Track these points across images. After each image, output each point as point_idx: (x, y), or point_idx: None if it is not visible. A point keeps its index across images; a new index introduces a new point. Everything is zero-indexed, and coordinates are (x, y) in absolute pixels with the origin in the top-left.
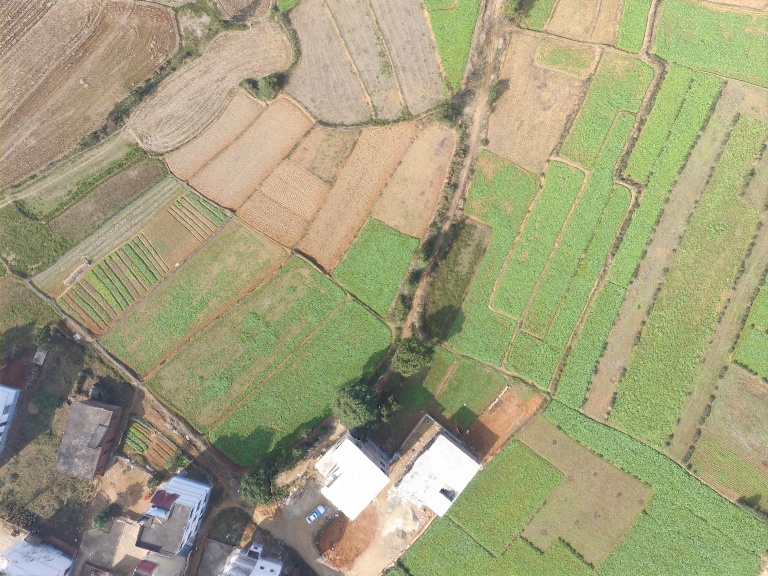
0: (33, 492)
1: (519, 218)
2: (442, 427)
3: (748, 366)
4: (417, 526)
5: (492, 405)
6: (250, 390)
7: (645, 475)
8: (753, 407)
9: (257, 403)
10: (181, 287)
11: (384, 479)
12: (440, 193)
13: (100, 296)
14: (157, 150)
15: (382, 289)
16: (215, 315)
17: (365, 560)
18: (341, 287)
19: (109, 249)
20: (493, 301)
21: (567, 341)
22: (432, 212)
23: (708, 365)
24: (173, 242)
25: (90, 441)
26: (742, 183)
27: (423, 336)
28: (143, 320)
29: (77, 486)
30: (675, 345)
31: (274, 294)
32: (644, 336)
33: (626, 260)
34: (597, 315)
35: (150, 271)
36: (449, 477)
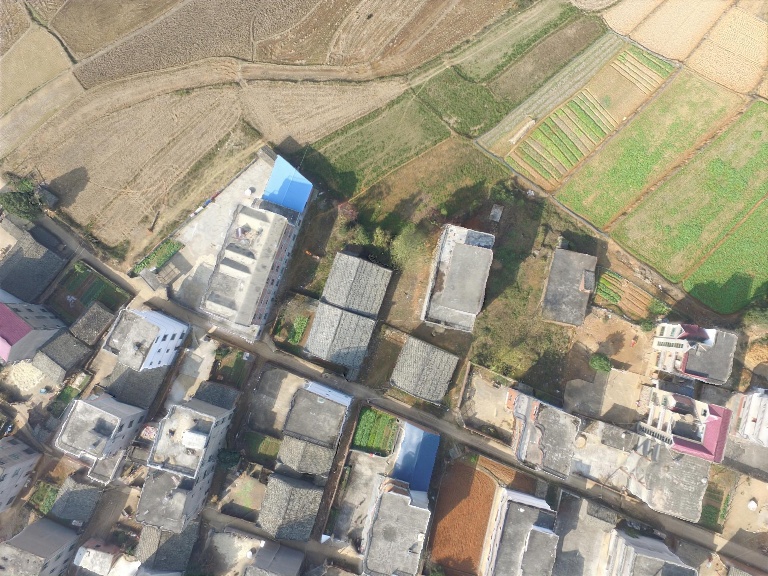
0: (507, 345)
1: None
2: None
3: None
4: None
5: None
6: (722, 237)
7: None
8: None
9: (732, 249)
10: (634, 139)
11: None
12: None
13: (548, 153)
14: (591, 8)
15: None
16: (672, 165)
17: None
18: None
19: (553, 107)
20: None
21: None
22: None
23: None
24: (619, 96)
25: (585, 284)
26: None
27: None
28: (597, 174)
29: (552, 338)
30: None
31: (738, 139)
32: None
33: None
34: None
35: (598, 126)
36: None
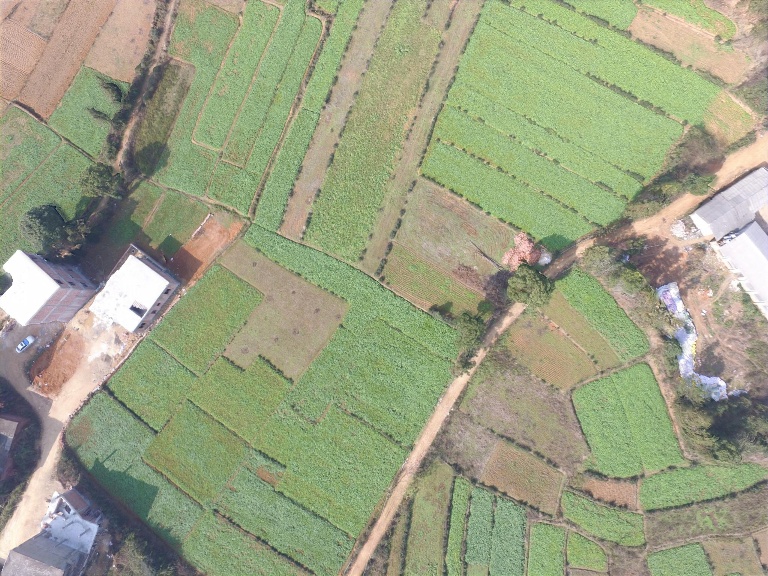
0: None
1: (220, 56)
2: (145, 255)
3: (435, 179)
4: (121, 350)
5: (195, 233)
6: None
7: (340, 290)
8: (442, 218)
9: None
10: None
11: (53, 285)
12: None
13: None
14: None
15: (95, 132)
16: None
17: (72, 385)
18: (56, 132)
19: None
20: (195, 134)
21: (265, 168)
22: (141, 57)
23: (398, 181)
24: None
25: None
26: (425, 6)
27: (127, 170)
28: None
29: None
30: (366, 164)
31: None
32: (337, 157)
33: (318, 87)
34: (292, 140)
35: None
36: (139, 294)
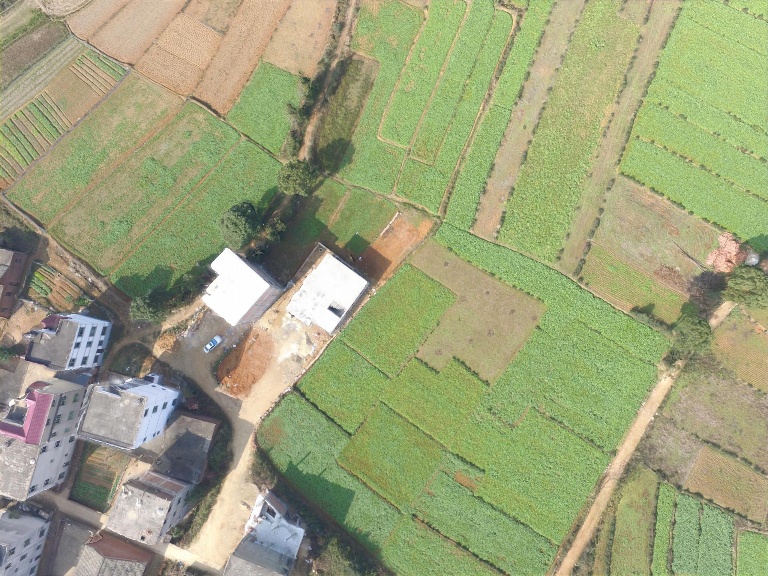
0: None
1: (404, 51)
2: (334, 254)
3: (635, 177)
4: (312, 351)
5: (383, 231)
6: (149, 232)
7: (537, 291)
8: (642, 218)
9: (156, 243)
10: (83, 139)
11: (263, 284)
12: (328, 34)
13: (6, 153)
14: (59, 14)
15: (275, 128)
16: (116, 164)
17: (262, 386)
18: (235, 129)
19: (15, 108)
20: (381, 131)
21: (455, 165)
22: (321, 52)
23: (595, 179)
24: (75, 98)
25: None
26: None
27: (313, 168)
28: (47, 172)
29: None
30: (561, 162)
31: (170, 139)
32: (530, 155)
33: (510, 82)
34: (483, 137)
35: (54, 127)
36: (337, 294)
